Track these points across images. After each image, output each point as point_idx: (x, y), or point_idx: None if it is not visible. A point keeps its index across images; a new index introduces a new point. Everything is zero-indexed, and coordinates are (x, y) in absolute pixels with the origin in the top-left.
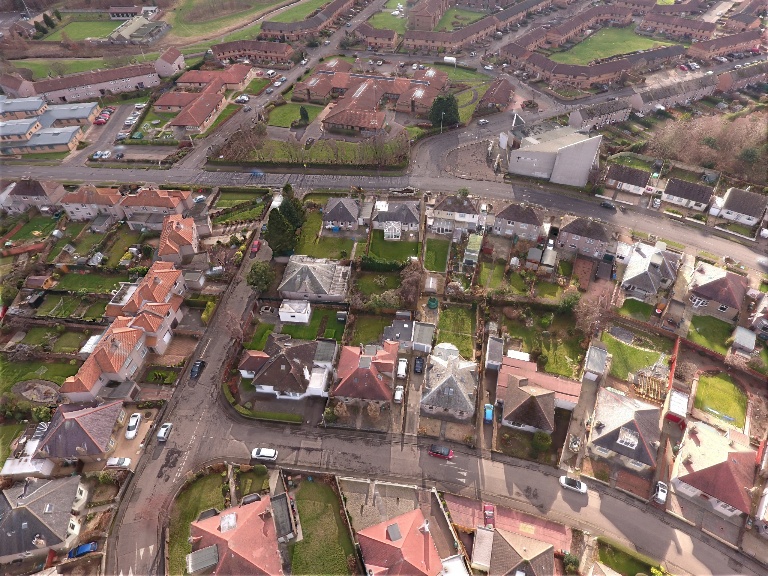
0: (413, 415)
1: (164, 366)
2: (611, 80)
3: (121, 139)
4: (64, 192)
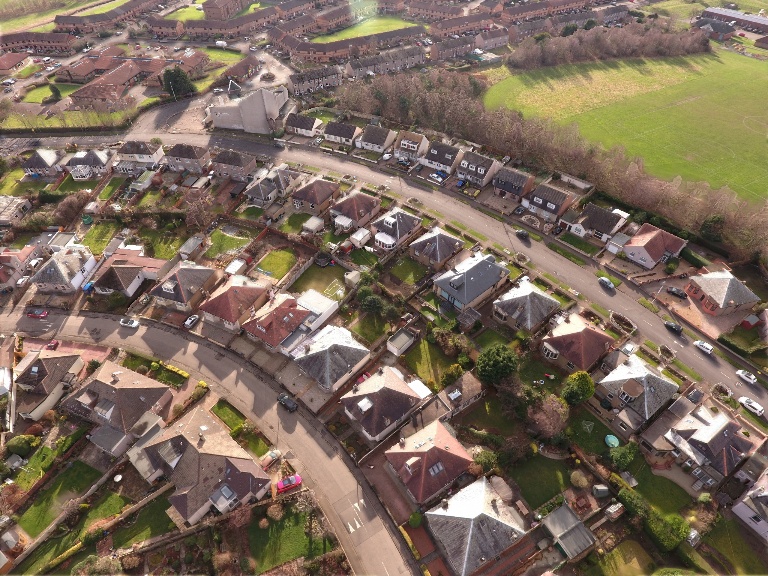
0: (30, 294)
1: None
2: (350, 55)
3: None
4: None
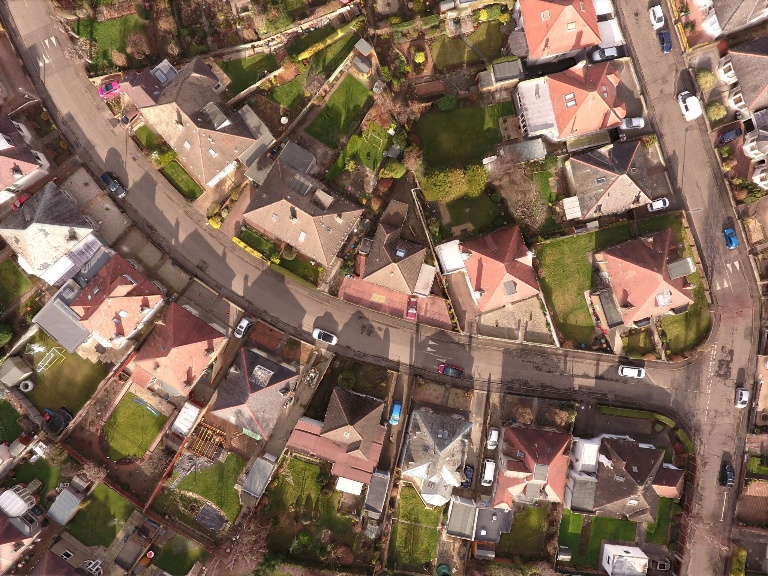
0: (477, 413)
1: (767, 480)
2: None
3: None
4: None
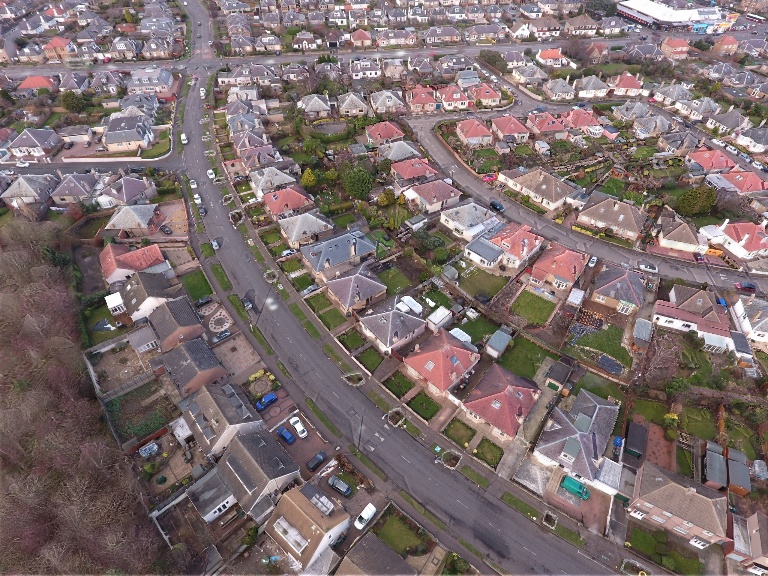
0: None
1: None
2: None
3: None
4: None
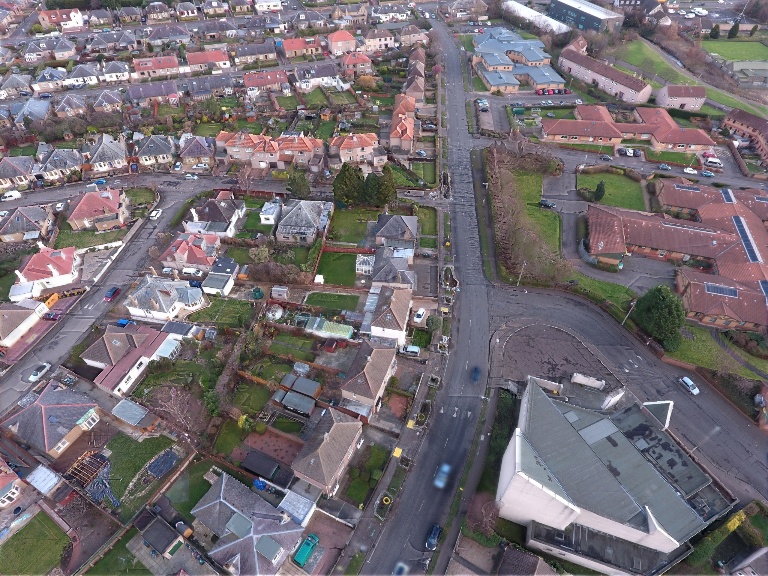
0: None
1: None
2: None
3: (512, 105)
4: (421, 98)
